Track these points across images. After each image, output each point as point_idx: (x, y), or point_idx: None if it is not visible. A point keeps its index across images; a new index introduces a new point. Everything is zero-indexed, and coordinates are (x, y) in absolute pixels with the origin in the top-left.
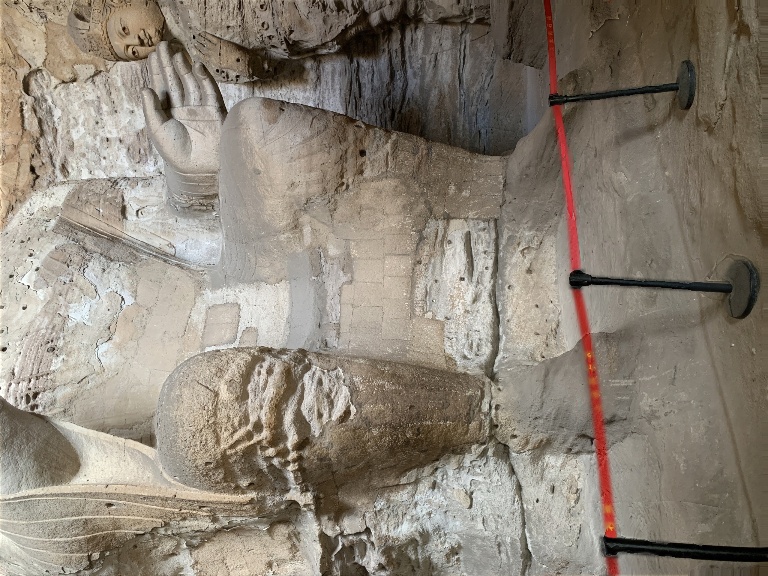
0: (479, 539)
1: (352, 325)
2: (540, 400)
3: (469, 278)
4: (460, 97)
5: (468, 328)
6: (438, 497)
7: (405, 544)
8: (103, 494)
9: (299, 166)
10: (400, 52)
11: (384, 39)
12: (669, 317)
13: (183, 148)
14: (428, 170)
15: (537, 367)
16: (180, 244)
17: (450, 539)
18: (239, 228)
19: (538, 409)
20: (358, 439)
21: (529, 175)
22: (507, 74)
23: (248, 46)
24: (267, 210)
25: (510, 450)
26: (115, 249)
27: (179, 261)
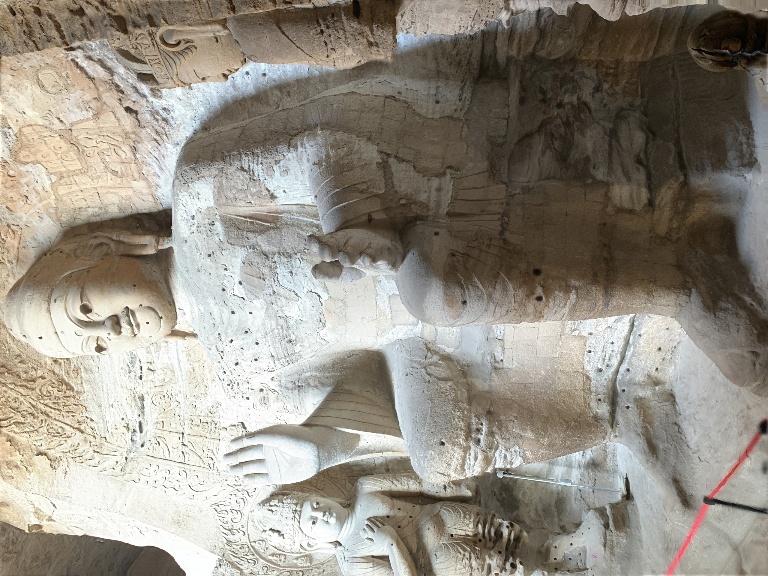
0: None
1: (514, 343)
2: None
3: None
4: None
5: (605, 341)
6: None
7: None
8: None
9: None
10: None
11: None
12: (722, 531)
13: None
14: None
15: (643, 456)
16: None
17: None
18: None
19: None
20: None
21: None
22: None
23: None
24: None
25: None
26: (285, 238)
27: None
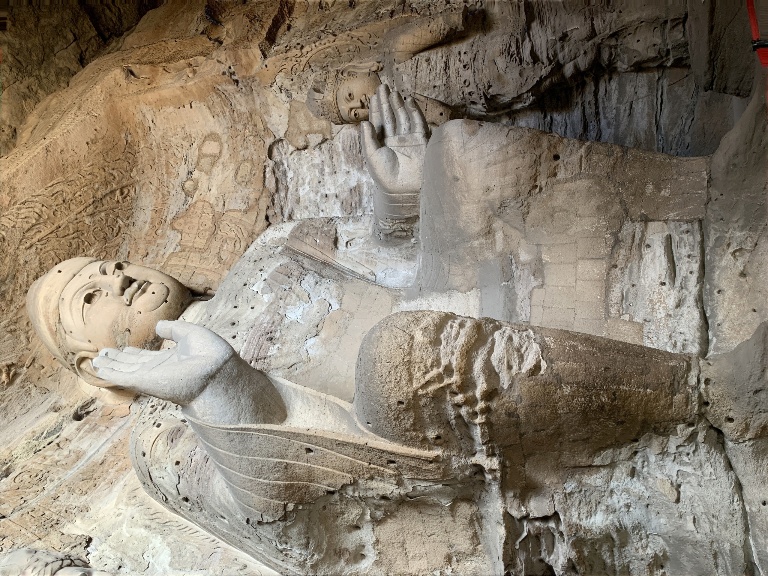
0: (689, 545)
1: (542, 323)
2: (760, 366)
3: (671, 283)
4: (658, 142)
5: (671, 330)
6: (638, 486)
7: (599, 540)
8: (305, 436)
9: (495, 171)
10: (594, 104)
11: (578, 92)
12: None
13: (392, 170)
14: (623, 170)
15: None
16: (380, 273)
17: (653, 544)
18: (436, 237)
19: (758, 378)
20: (548, 396)
21: (737, 164)
22: (710, 115)
23: (450, 103)
24: (463, 216)
25: (725, 439)
26: (326, 270)
27: (379, 284)
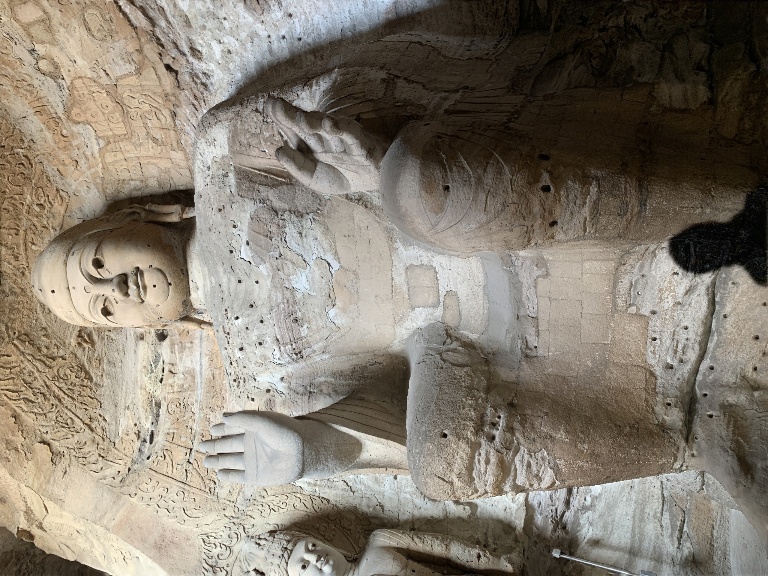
0: None
1: (550, 322)
2: None
3: (684, 272)
4: None
5: (675, 324)
6: None
7: None
8: None
9: (478, 241)
10: None
11: None
12: None
13: (341, 188)
14: (639, 229)
15: (731, 477)
16: None
17: None
18: None
19: None
20: None
21: None
22: None
23: None
24: None
25: None
26: (298, 196)
27: None
